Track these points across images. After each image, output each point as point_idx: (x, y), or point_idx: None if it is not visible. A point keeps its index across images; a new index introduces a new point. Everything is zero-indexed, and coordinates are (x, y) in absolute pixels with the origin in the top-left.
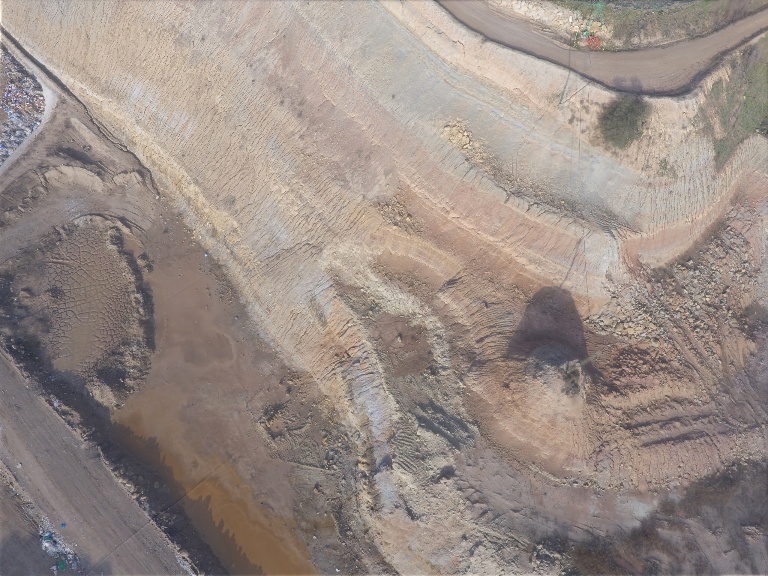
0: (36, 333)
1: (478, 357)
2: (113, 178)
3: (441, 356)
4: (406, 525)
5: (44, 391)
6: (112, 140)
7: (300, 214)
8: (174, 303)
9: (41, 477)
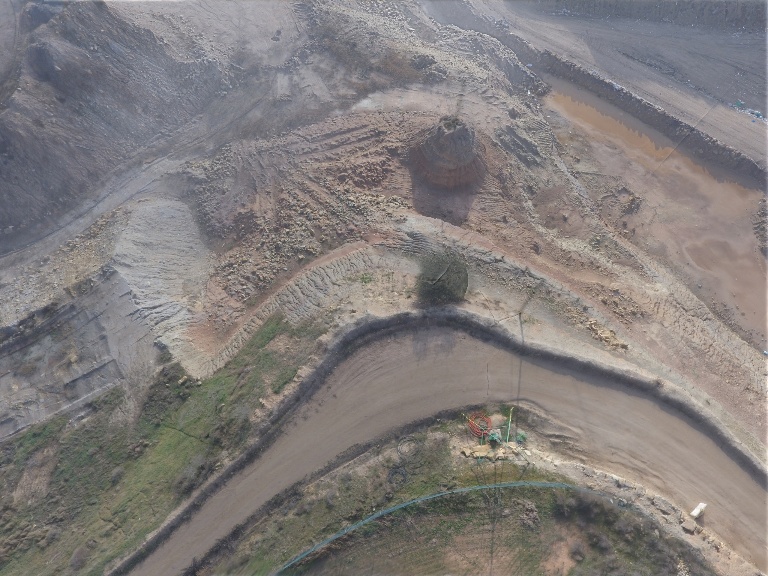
0: None
1: None
2: None
3: (527, 199)
4: None
5: None
6: None
7: None
8: None
9: None
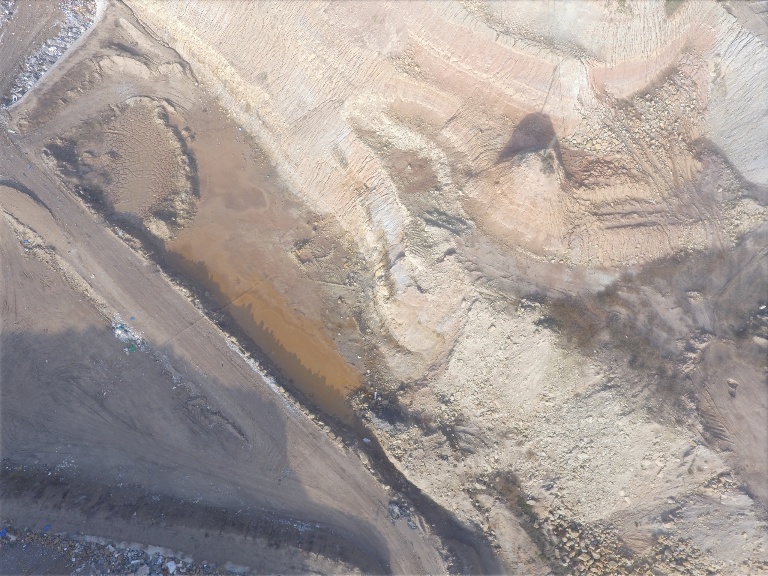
0: (99, 184)
1: (474, 171)
2: (158, 68)
3: (444, 177)
4: (416, 299)
5: (109, 224)
6: (156, 38)
7: (324, 76)
8: (215, 164)
9: (112, 285)
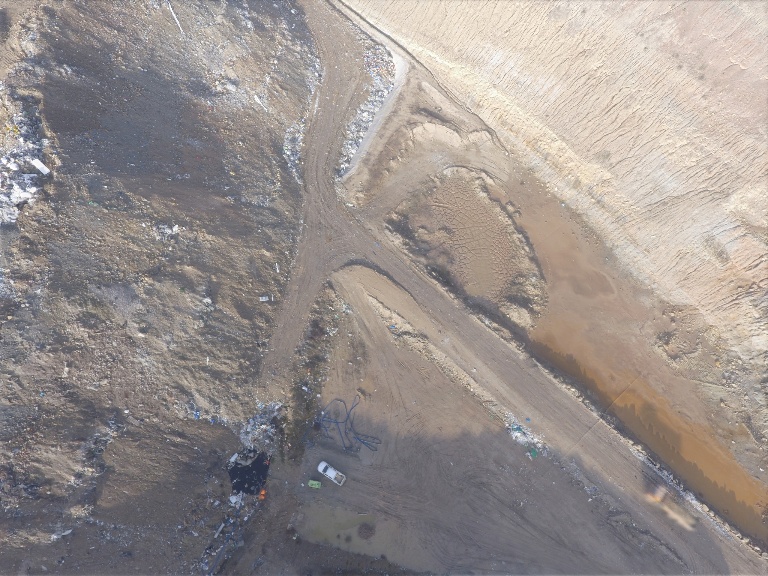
0: (444, 264)
1: None
2: (468, 135)
3: None
4: None
5: (472, 311)
6: (458, 103)
7: (700, 164)
8: (549, 244)
9: (496, 380)
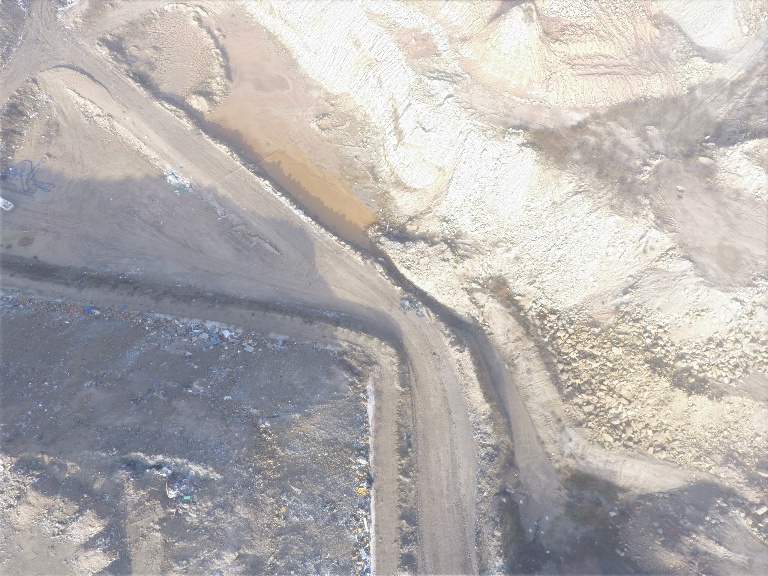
0: (145, 70)
1: (468, 36)
2: None
3: (443, 45)
4: (421, 139)
5: (157, 99)
6: None
7: None
8: (244, 57)
9: (162, 143)
